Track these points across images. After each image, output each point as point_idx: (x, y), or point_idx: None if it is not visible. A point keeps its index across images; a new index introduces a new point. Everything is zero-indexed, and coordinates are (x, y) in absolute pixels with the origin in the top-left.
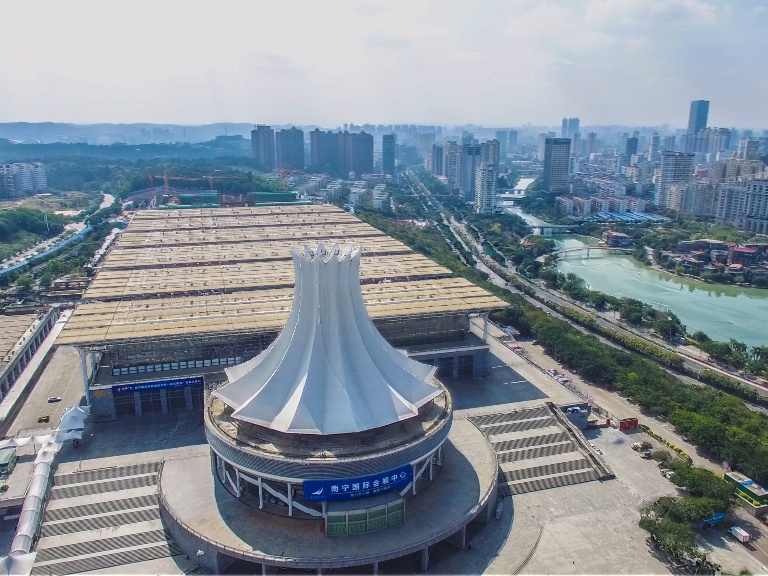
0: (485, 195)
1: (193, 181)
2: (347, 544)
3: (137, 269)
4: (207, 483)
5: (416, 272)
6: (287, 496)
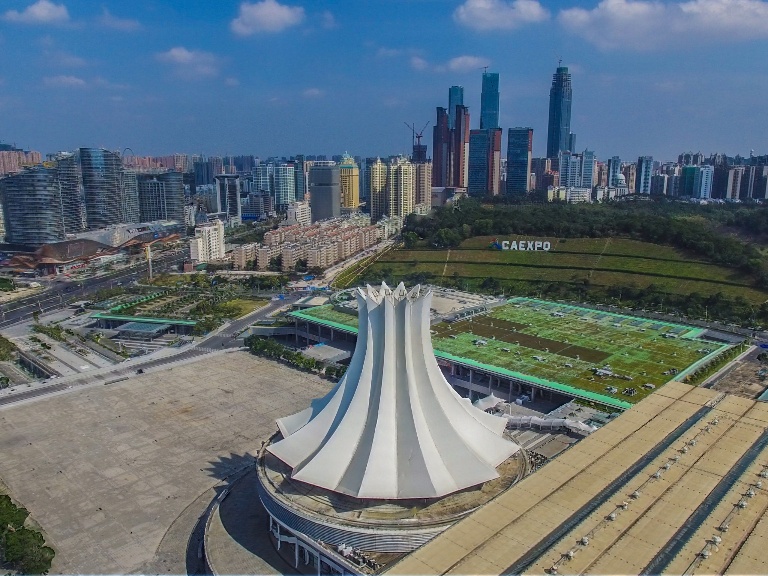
0: None
1: None
2: None
3: None
4: None
5: None
6: None
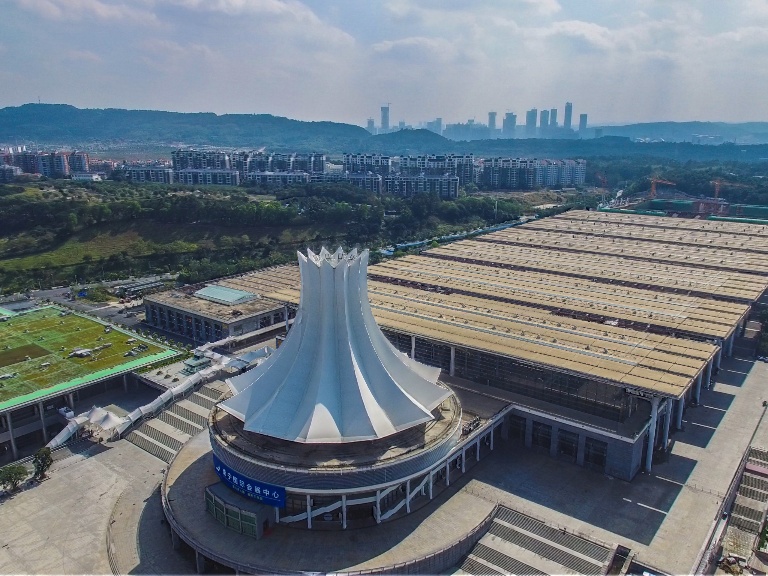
0: None
1: (670, 185)
2: (204, 523)
3: (441, 258)
4: None
5: (674, 323)
6: None
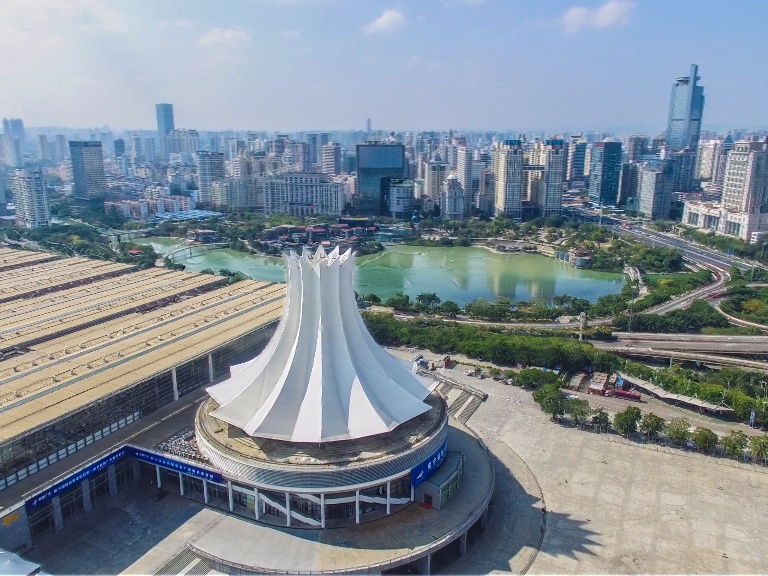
0: (36, 206)
1: None
2: (459, 505)
3: None
4: (274, 535)
5: (194, 283)
6: (386, 496)
